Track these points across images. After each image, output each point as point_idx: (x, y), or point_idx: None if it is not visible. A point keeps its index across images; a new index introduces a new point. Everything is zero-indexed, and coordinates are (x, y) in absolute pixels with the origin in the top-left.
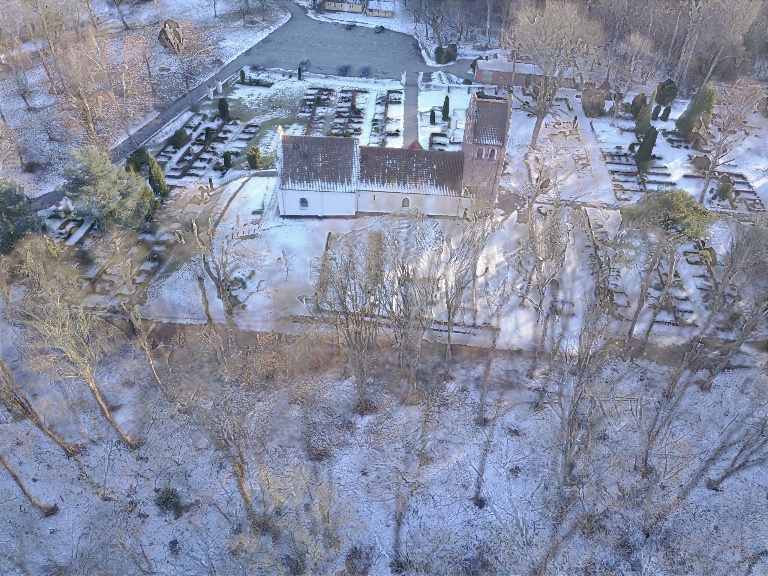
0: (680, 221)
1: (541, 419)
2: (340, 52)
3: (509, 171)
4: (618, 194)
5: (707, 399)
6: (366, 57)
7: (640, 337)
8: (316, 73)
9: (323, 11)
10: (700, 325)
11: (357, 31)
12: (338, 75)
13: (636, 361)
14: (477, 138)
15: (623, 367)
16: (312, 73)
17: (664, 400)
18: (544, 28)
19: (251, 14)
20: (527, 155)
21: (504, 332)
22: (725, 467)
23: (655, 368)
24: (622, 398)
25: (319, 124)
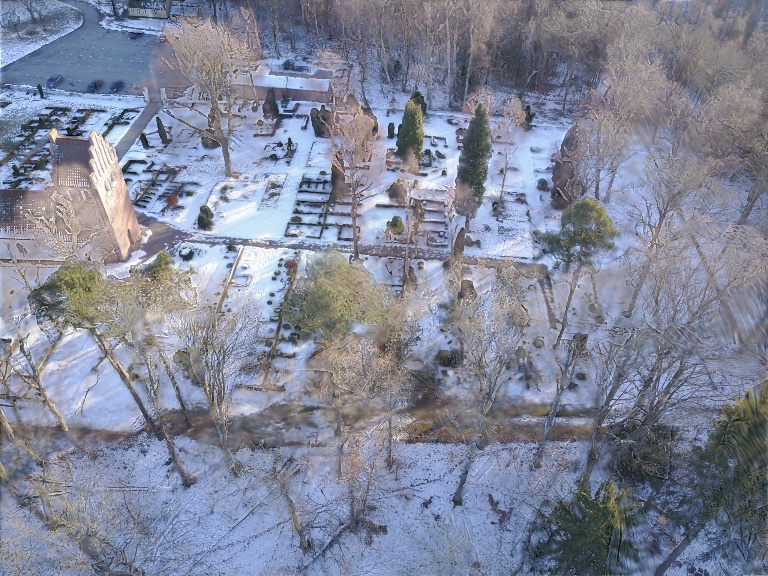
0: (57, 306)
1: (20, 517)
2: (106, 65)
3: (185, 204)
4: (290, 229)
5: (230, 486)
6: (131, 70)
7: (208, 406)
8: (62, 90)
9: (124, 18)
10: (288, 389)
11: (142, 40)
12: (86, 92)
13: (175, 439)
14: (62, 180)
15: (155, 447)
16: (58, 90)
17: (179, 489)
18: (186, 49)
19: (37, 23)
20: (216, 184)
21: (55, 404)
22: (222, 570)
23: (193, 448)
24: (131, 488)
25: (26, 150)
